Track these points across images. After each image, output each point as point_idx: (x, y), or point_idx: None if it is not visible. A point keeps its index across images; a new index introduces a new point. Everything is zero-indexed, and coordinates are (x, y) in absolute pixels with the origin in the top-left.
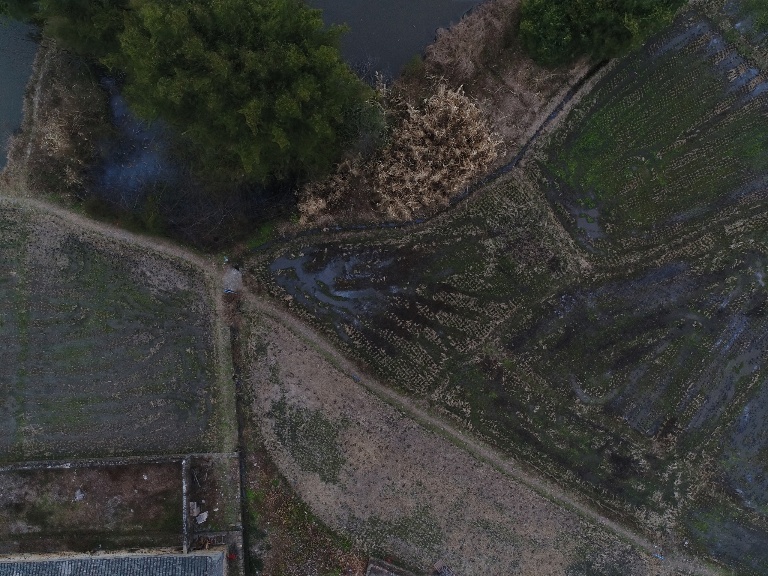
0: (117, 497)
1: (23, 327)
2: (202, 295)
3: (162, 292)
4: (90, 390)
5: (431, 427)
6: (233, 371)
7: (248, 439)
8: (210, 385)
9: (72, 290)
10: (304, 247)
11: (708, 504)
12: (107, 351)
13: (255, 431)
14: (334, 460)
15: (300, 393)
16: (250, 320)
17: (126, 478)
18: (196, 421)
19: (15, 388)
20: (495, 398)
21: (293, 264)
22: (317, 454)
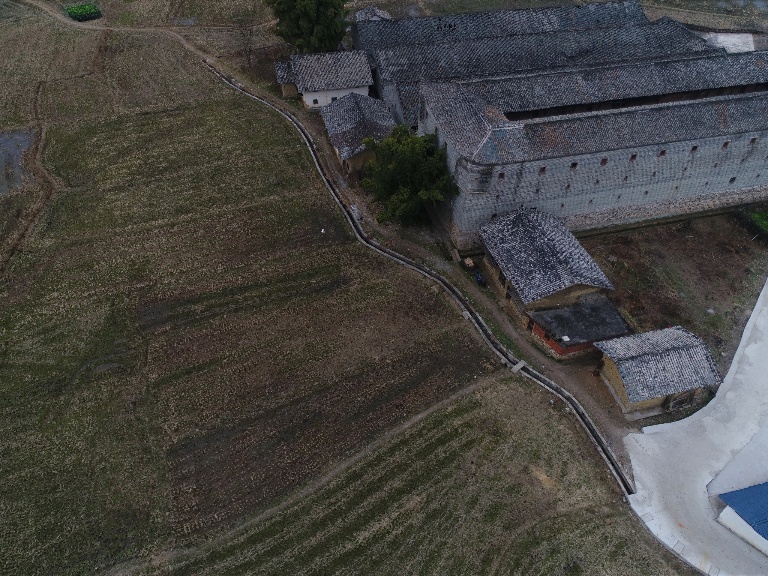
0: None
1: (511, 3)
2: None
3: None
4: None
5: (660, 8)
6: None
7: None
8: None
9: None
10: None
11: (764, 14)
12: None
13: None
14: None
15: None
16: None
17: None
18: None
19: None
20: (675, 5)
21: None
22: None
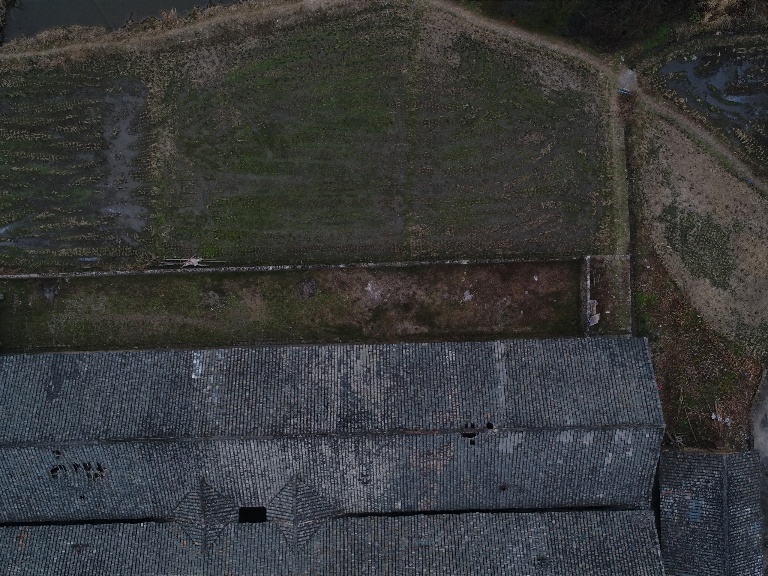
0: (506, 298)
1: (413, 125)
2: (595, 96)
3: (555, 92)
4: (479, 191)
5: None
6: (626, 173)
7: (641, 241)
8: (601, 187)
9: (463, 89)
10: (697, 50)
11: None
12: (497, 151)
13: (648, 234)
14: (724, 266)
15: (691, 197)
16: (643, 122)
17: (517, 279)
18: (586, 223)
19: (403, 187)
20: None
21: (684, 68)
22: (707, 259)
